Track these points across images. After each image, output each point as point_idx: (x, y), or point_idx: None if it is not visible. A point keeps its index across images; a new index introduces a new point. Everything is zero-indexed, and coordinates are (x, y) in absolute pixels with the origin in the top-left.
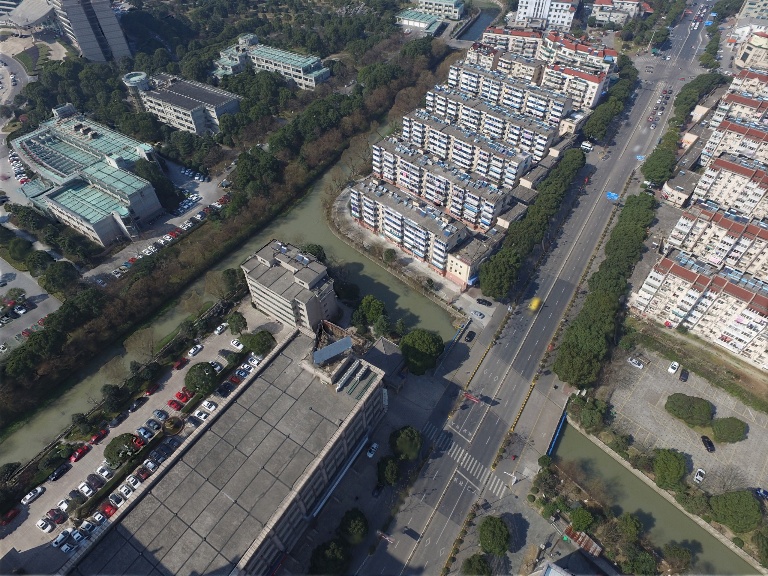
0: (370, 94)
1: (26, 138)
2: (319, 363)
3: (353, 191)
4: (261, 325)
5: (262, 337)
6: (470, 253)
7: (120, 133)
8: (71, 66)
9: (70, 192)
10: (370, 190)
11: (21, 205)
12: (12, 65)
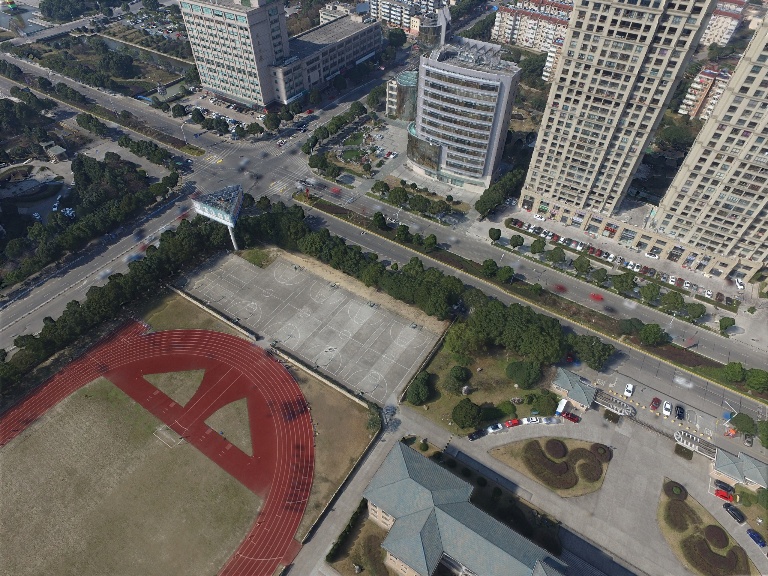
0: None
1: None
2: (358, 13)
3: None
4: None
5: None
6: (421, 17)
7: None
8: None
9: None
10: None
11: None
12: None
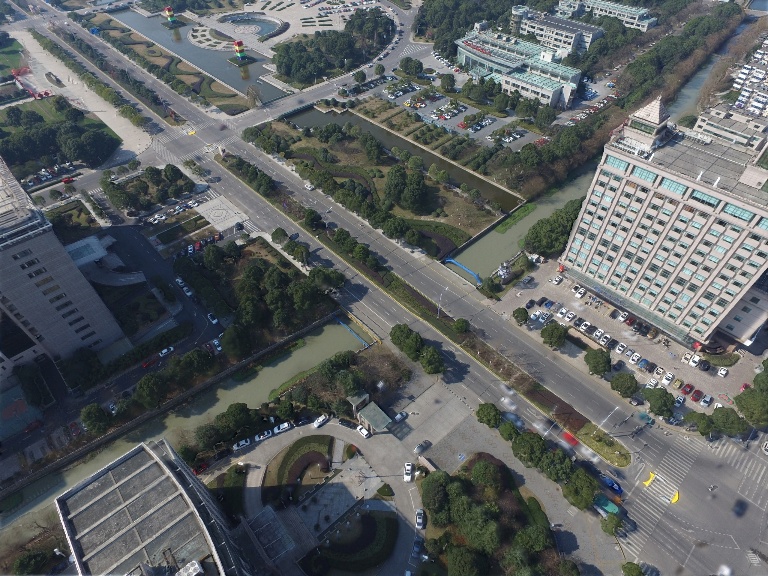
0: None
1: (464, 40)
2: None
3: (747, 89)
4: None
5: None
6: None
7: (533, 42)
8: (454, 1)
9: (516, 74)
10: (764, 89)
11: (484, 79)
12: (383, 2)
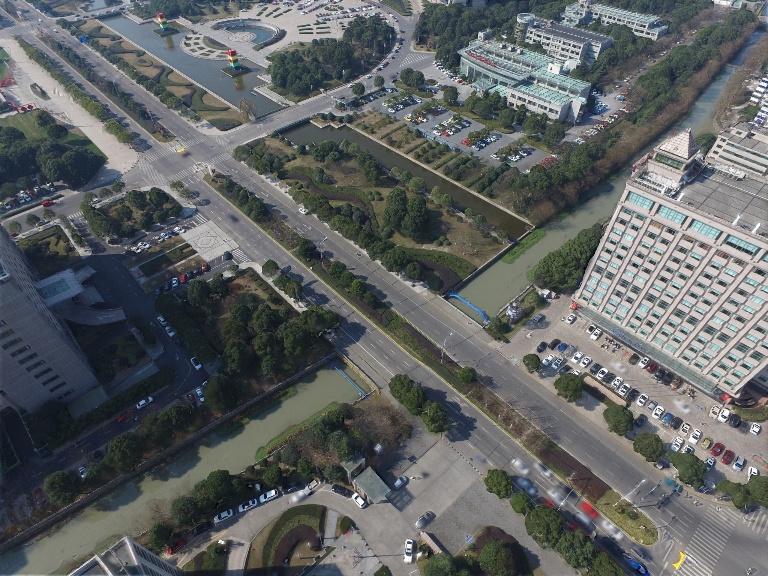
0: (715, 48)
1: (467, 50)
2: None
3: (767, 105)
4: None
5: None
6: None
7: (540, 53)
8: (456, 8)
9: (523, 87)
10: None
11: None
12: (383, 8)
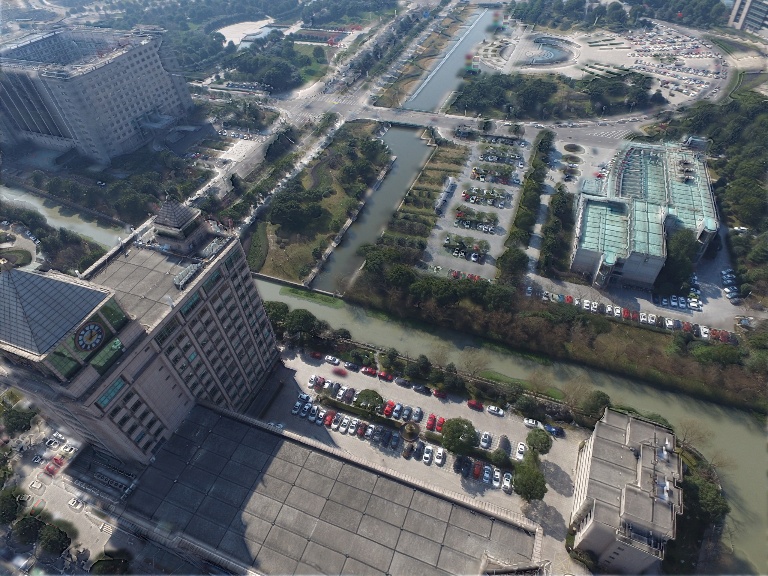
0: None
1: (641, 147)
2: None
3: None
4: (560, 466)
5: (531, 478)
6: None
7: (714, 195)
8: None
9: (607, 210)
10: None
11: (569, 192)
12: (730, 81)
